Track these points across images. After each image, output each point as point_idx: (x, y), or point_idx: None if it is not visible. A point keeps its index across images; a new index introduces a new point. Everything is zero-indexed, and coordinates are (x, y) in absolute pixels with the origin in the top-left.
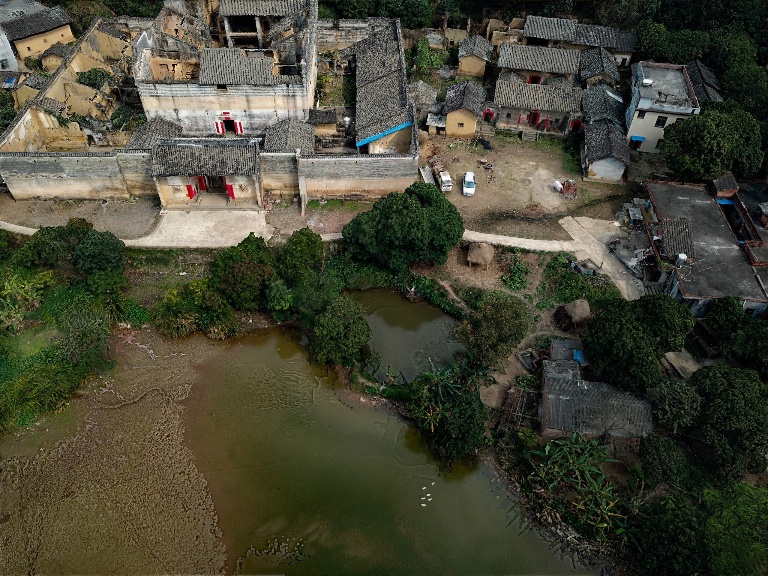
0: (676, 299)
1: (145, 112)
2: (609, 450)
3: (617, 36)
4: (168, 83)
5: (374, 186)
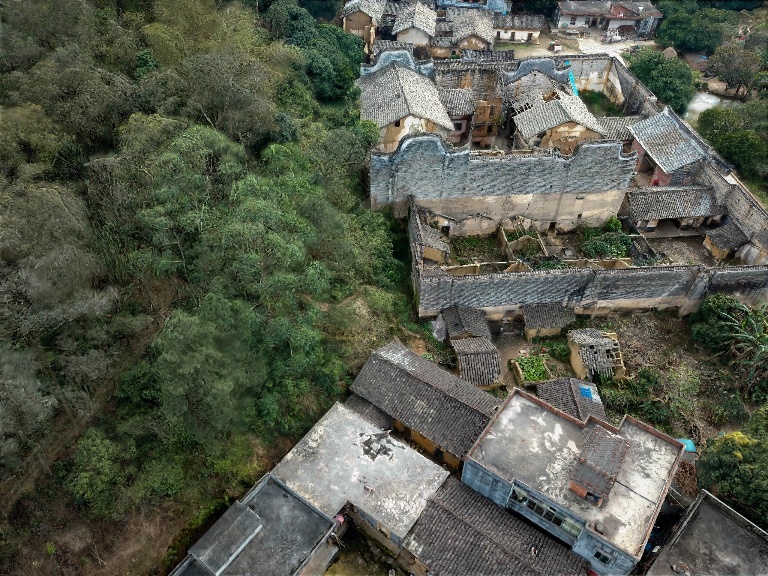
0: None
1: None
2: None
3: None
4: None
5: None
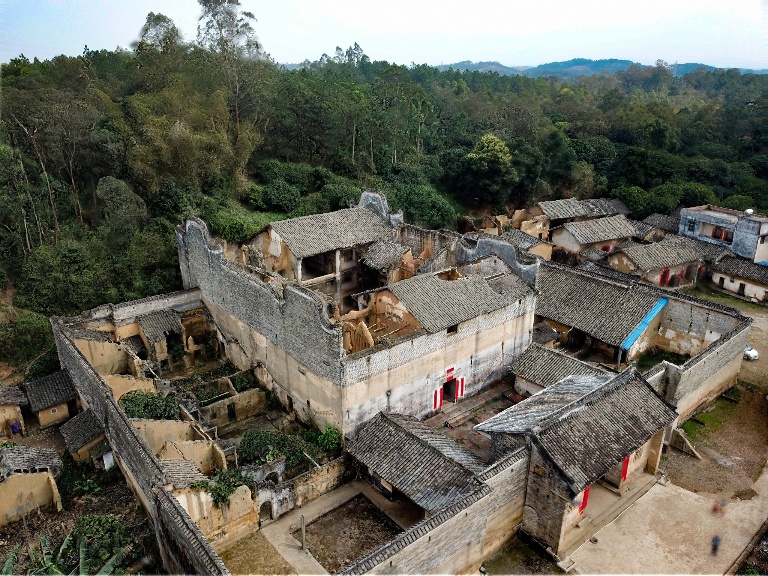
0: None
1: (343, 415)
2: None
3: None
4: (389, 347)
5: (716, 382)
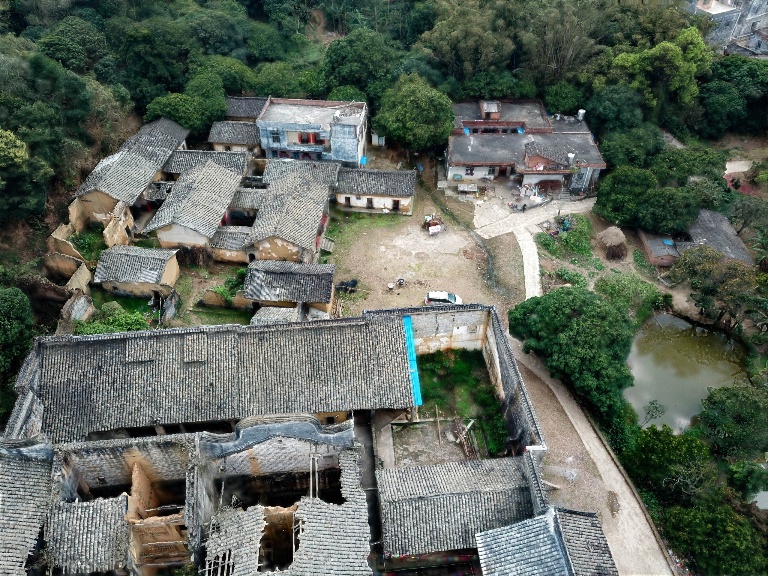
0: (590, 178)
1: None
2: (760, 233)
3: (162, 132)
4: None
5: None
